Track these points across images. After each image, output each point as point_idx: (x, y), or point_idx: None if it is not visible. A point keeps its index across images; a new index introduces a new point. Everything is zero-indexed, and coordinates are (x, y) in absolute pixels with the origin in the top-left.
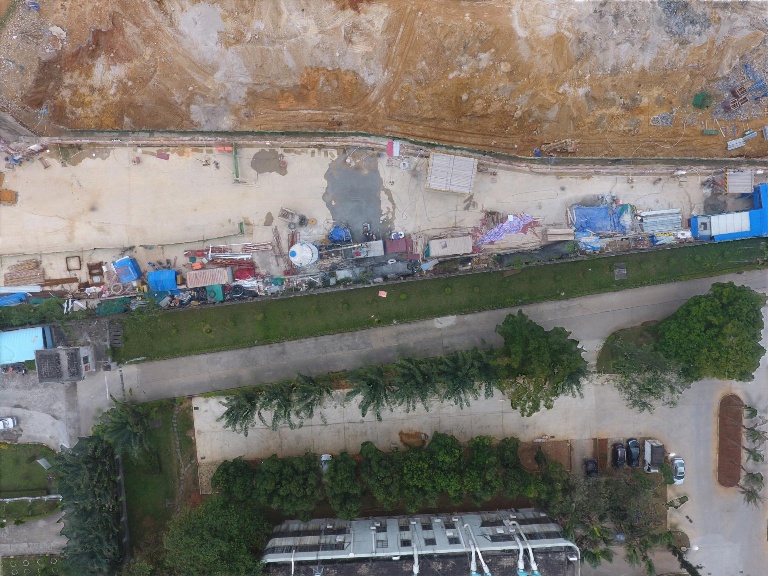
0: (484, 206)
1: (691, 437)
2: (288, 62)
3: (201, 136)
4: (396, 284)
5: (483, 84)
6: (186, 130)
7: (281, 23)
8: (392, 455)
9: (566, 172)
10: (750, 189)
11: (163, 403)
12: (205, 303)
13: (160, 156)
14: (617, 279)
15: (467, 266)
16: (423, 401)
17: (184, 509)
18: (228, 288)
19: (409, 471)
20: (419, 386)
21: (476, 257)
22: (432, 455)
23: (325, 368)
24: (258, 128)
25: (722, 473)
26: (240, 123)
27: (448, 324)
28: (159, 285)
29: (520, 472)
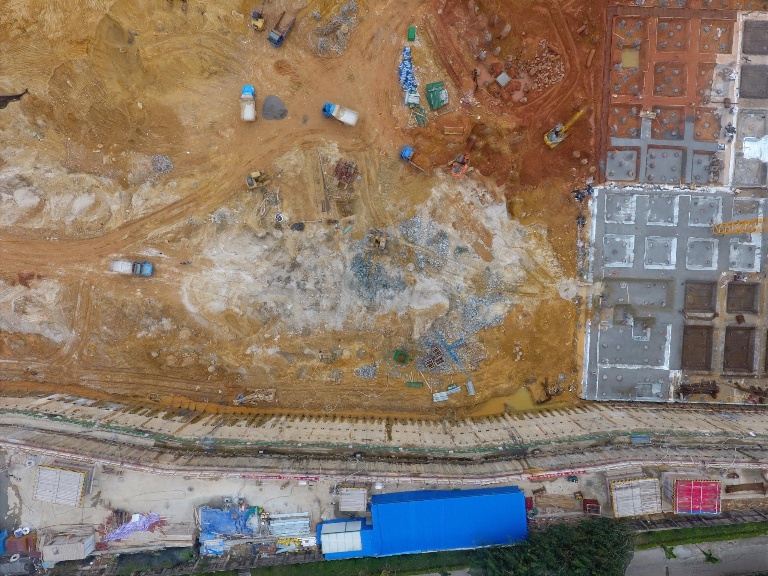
0: (111, 504)
1: None
2: None
3: None
4: None
5: (171, 344)
6: None
7: None
8: None
9: None
10: (363, 508)
11: None
12: None
13: None
14: None
15: (88, 566)
16: None
17: None
18: None
19: None
20: None
21: (99, 556)
22: None
23: None
24: None
25: None
26: None
27: None
28: None
29: None
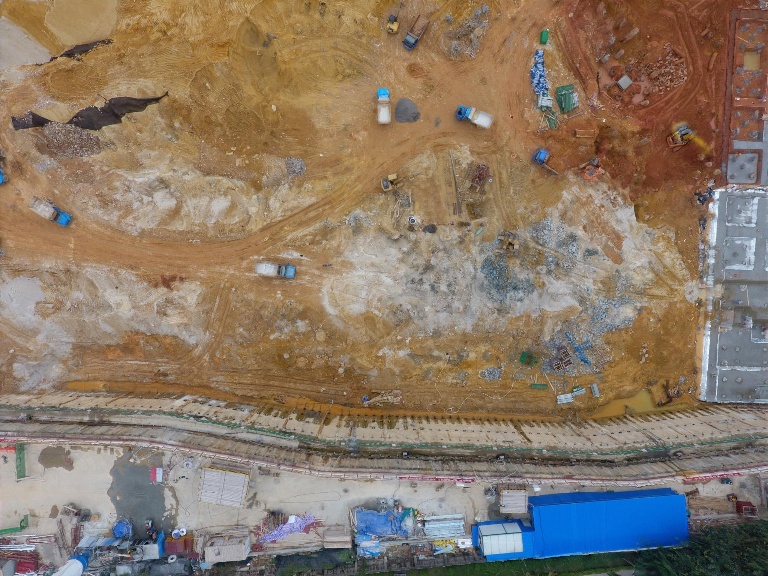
0: (267, 505)
1: None
2: (106, 329)
3: (8, 410)
4: None
5: (303, 346)
6: None
7: (99, 294)
8: None
9: None
10: (524, 510)
11: None
12: None
13: None
14: None
15: (245, 567)
16: None
17: None
18: None
19: None
20: None
21: (256, 557)
22: None
23: None
24: (86, 376)
25: None
26: (69, 371)
27: None
28: None
29: None
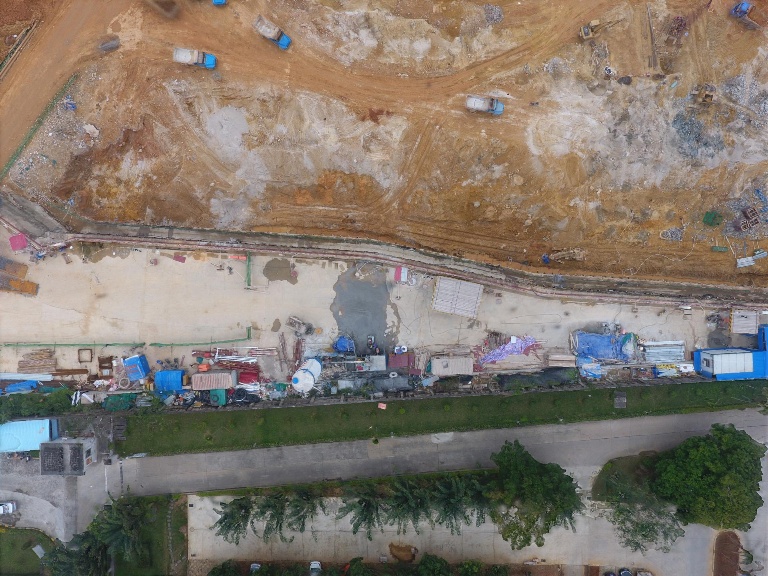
0: (488, 326)
1: (685, 571)
2: (307, 165)
3: (218, 235)
4: None
5: (495, 193)
6: (204, 228)
7: (303, 128)
8: None
9: (571, 298)
10: (754, 330)
11: (159, 499)
12: (208, 405)
13: (177, 259)
14: (617, 407)
15: (467, 385)
16: (414, 524)
17: None
18: (231, 392)
19: None
20: (411, 509)
21: (477, 376)
22: None
23: (320, 475)
24: (274, 221)
25: None
26: (257, 215)
27: (445, 440)
28: (165, 385)
29: None
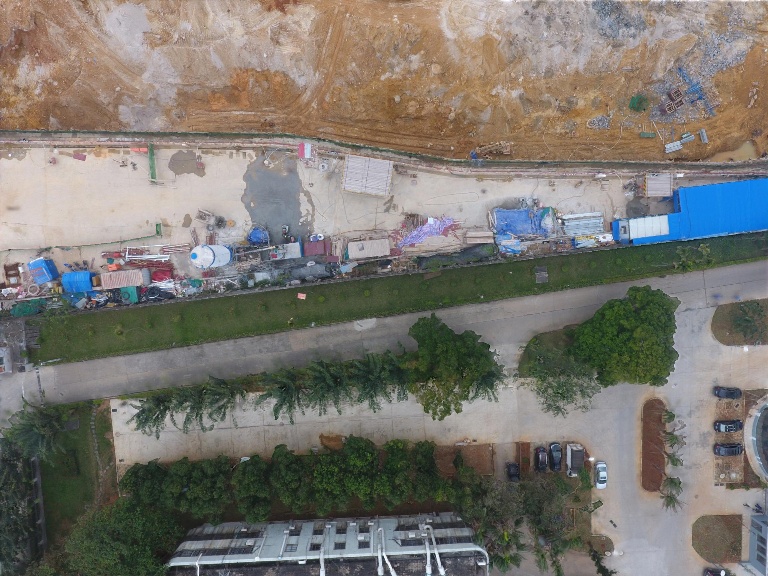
0: (404, 208)
1: (614, 441)
2: (216, 63)
3: (124, 137)
4: (315, 286)
5: (415, 86)
6: (109, 131)
7: (208, 24)
8: (303, 458)
9: (487, 175)
10: (669, 193)
11: (80, 405)
12: (121, 305)
13: (77, 157)
14: (538, 282)
15: (386, 269)
16: (335, 404)
17: (88, 512)
18: (144, 290)
19: (319, 475)
20: (331, 389)
21: (396, 260)
22: (345, 458)
23: (244, 370)
24: (190, 129)
25: (646, 477)
26: (172, 124)
27: (368, 327)
28: (74, 286)
29: (432, 476)
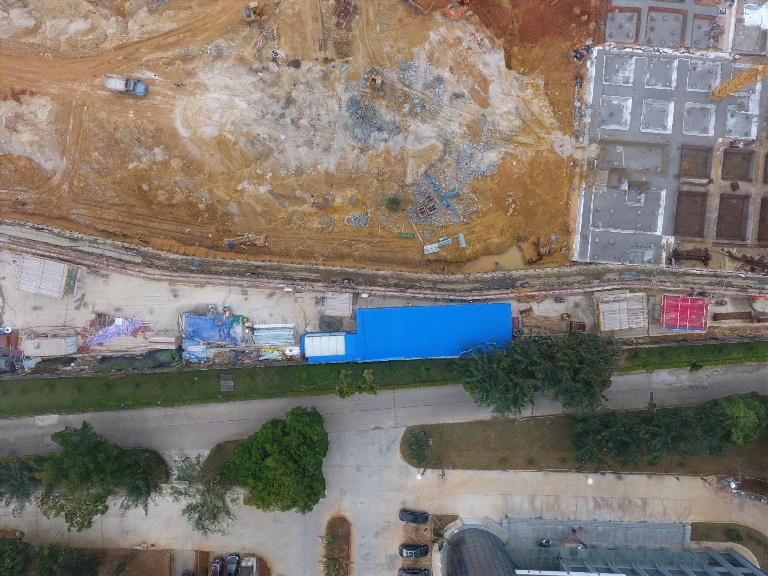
0: (95, 307)
1: (297, 557)
2: None
3: None
4: None
5: (162, 176)
6: None
7: None
8: None
9: (178, 280)
10: (348, 313)
11: None
12: None
13: None
14: (223, 390)
15: (69, 367)
16: None
17: None
18: None
19: None
20: None
21: (80, 358)
22: None
23: None
24: None
25: None
26: None
27: (49, 423)
28: None
29: None
